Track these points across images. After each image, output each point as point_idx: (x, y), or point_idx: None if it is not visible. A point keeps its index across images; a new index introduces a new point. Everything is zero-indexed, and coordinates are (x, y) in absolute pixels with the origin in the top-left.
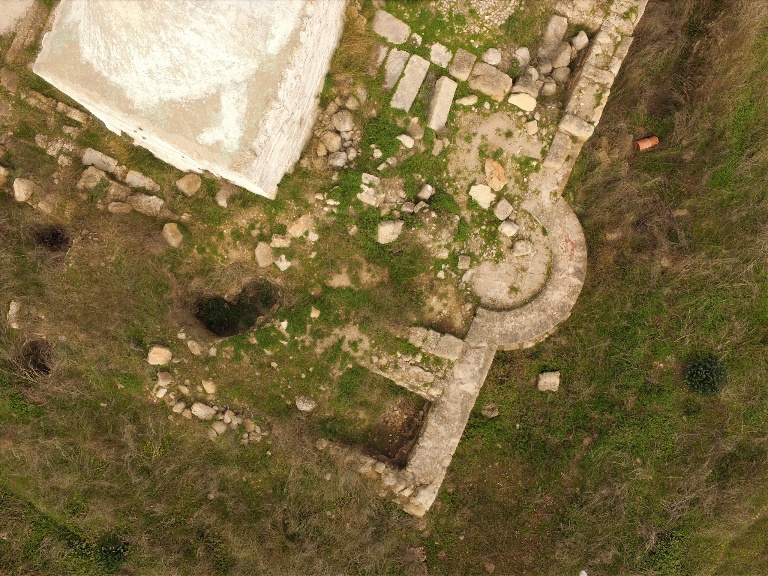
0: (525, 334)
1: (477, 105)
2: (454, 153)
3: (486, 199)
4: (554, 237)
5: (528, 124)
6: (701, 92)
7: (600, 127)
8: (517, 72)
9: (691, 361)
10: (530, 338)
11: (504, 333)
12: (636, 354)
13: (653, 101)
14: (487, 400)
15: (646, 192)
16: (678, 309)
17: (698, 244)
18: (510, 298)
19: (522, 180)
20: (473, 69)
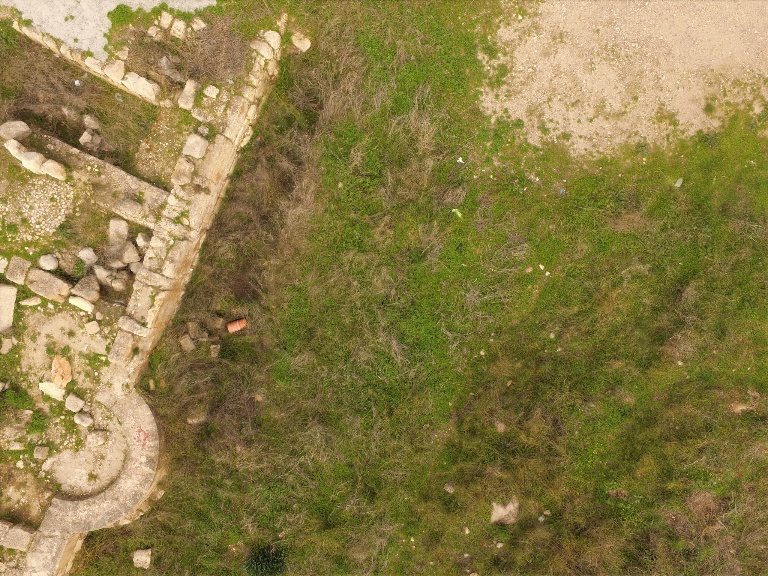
0: (98, 522)
1: (42, 305)
2: (24, 350)
3: (57, 393)
4: (127, 428)
5: (85, 326)
6: (271, 284)
7: (181, 315)
8: (79, 273)
9: (251, 550)
10: (103, 526)
11: (78, 522)
12: (213, 537)
13: (241, 286)
14: (86, 575)
15: (234, 374)
16: (245, 497)
17: (263, 434)
18: (89, 485)
19: (93, 374)
20: (27, 275)
